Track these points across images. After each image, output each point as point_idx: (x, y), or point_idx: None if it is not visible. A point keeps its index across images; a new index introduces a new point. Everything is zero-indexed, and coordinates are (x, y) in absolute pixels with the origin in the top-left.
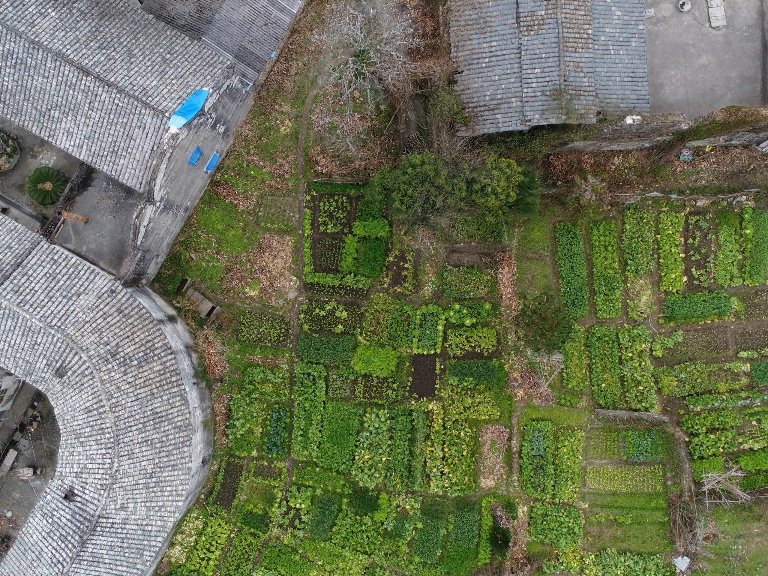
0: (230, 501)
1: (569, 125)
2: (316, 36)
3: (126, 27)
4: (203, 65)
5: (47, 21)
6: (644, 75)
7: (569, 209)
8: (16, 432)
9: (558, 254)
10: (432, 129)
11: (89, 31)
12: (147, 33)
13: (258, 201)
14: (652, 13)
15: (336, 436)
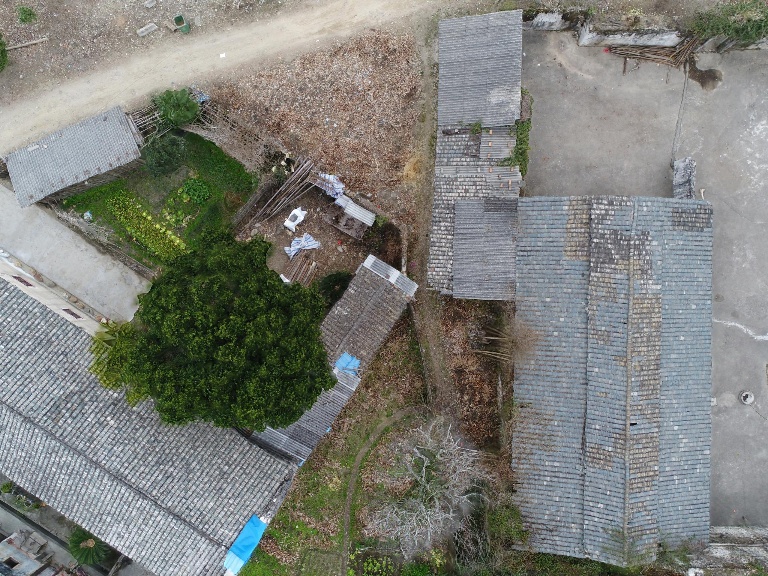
0: None
1: None
2: (371, 393)
3: (185, 433)
4: (261, 477)
5: (106, 433)
6: (706, 501)
7: None
8: None
9: None
10: (484, 512)
11: (148, 442)
12: (206, 440)
13: (301, 555)
14: (714, 403)
15: None
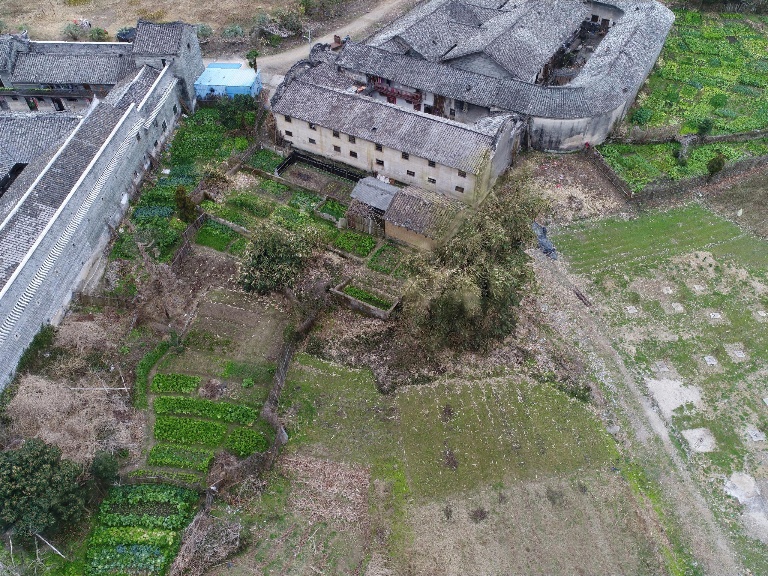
0: None
1: None
2: None
3: None
4: None
5: None
6: None
7: (762, 16)
8: None
9: (765, 21)
10: None
11: None
12: None
13: None
14: None
15: None
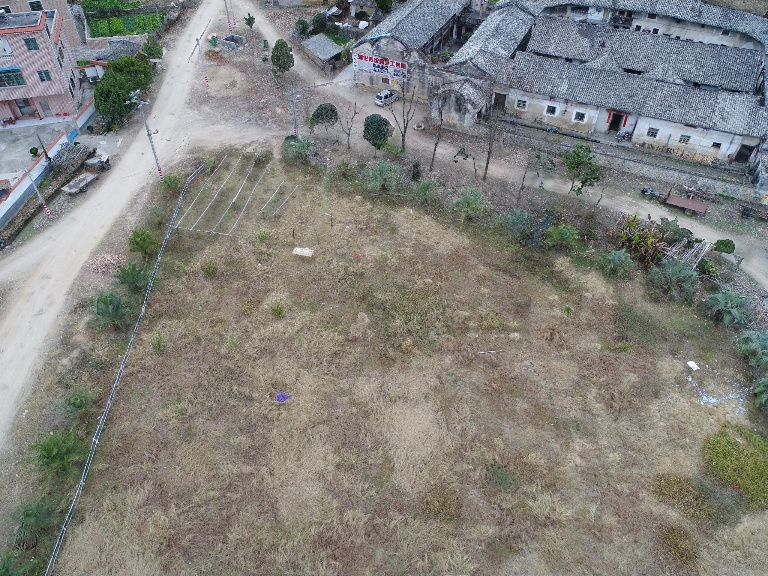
0: None
1: None
2: None
3: None
4: None
5: None
6: None
7: None
8: None
9: None
10: None
11: None
12: None
13: None
14: None
15: None
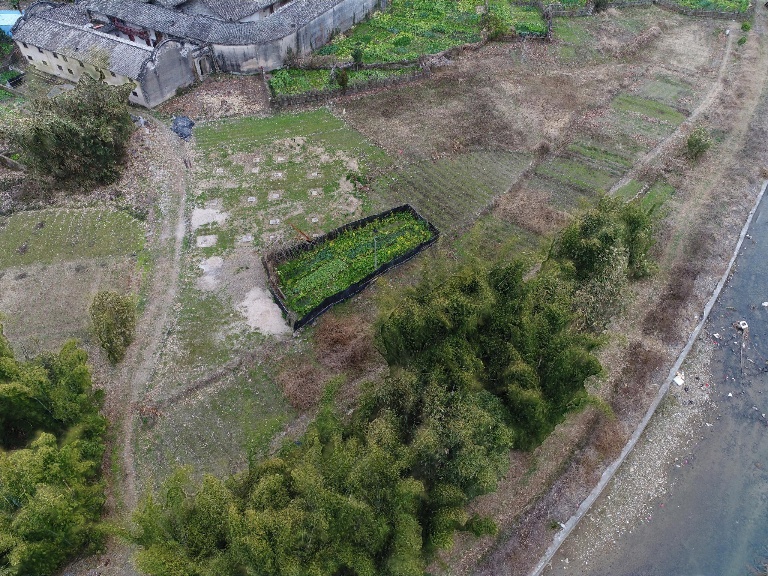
0: None
1: None
2: None
3: None
4: None
5: None
6: None
7: None
8: None
9: None
10: None
11: None
12: None
13: None
14: None
15: (428, 5)
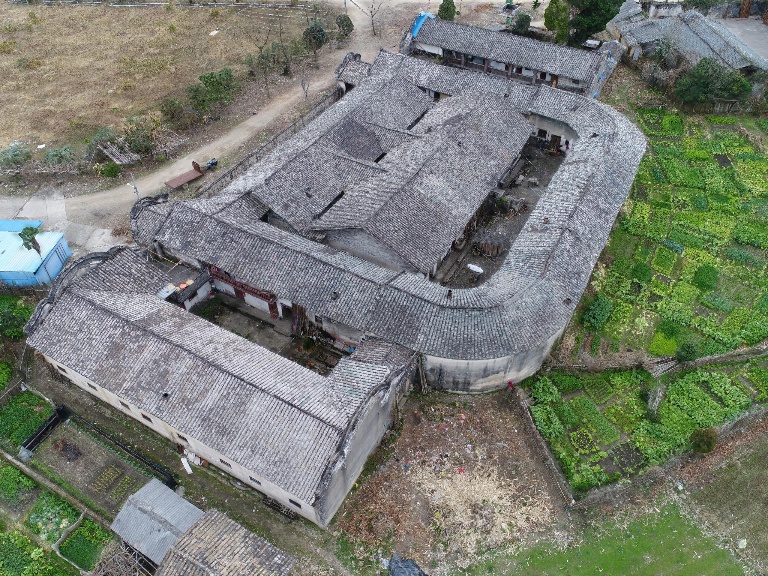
0: (645, 198)
1: (752, 71)
2: None
3: None
4: None
5: None
6: None
7: (760, 118)
8: (516, 177)
9: (764, 128)
10: None
11: None
12: None
13: None
14: None
15: None
